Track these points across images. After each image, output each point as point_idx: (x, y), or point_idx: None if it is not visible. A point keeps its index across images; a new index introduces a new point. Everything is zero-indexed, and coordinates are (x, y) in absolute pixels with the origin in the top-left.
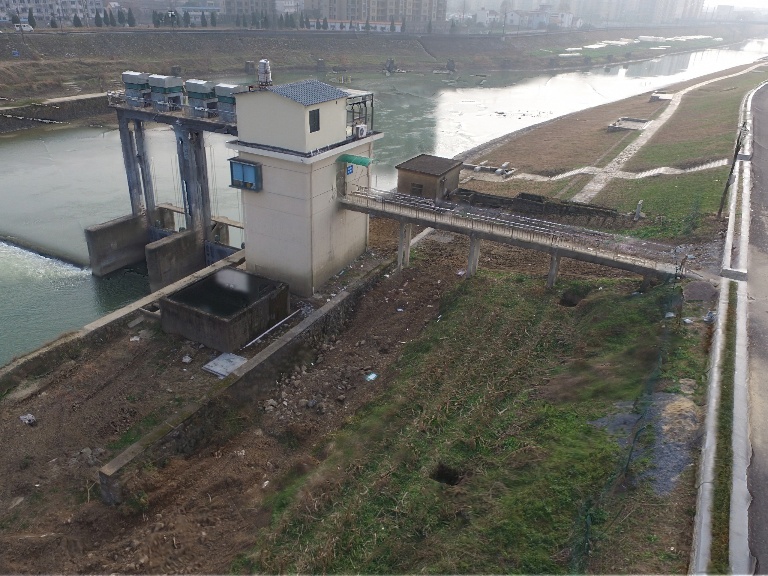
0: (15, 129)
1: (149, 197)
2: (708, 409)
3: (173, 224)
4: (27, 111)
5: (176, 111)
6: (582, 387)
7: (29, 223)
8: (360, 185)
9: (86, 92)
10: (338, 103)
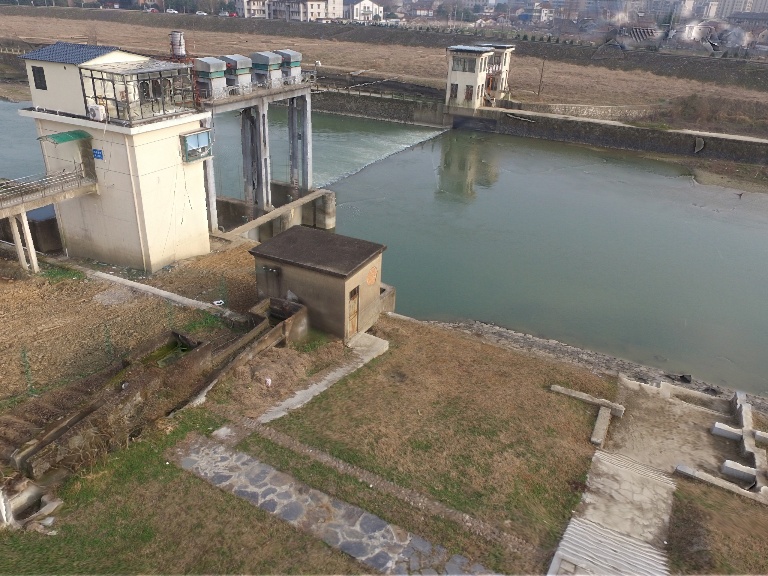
0: (620, 147)
1: (305, 175)
2: None
3: (326, 213)
4: (641, 133)
5: (259, 88)
6: None
7: (369, 186)
8: (121, 182)
9: (742, 133)
10: (68, 69)
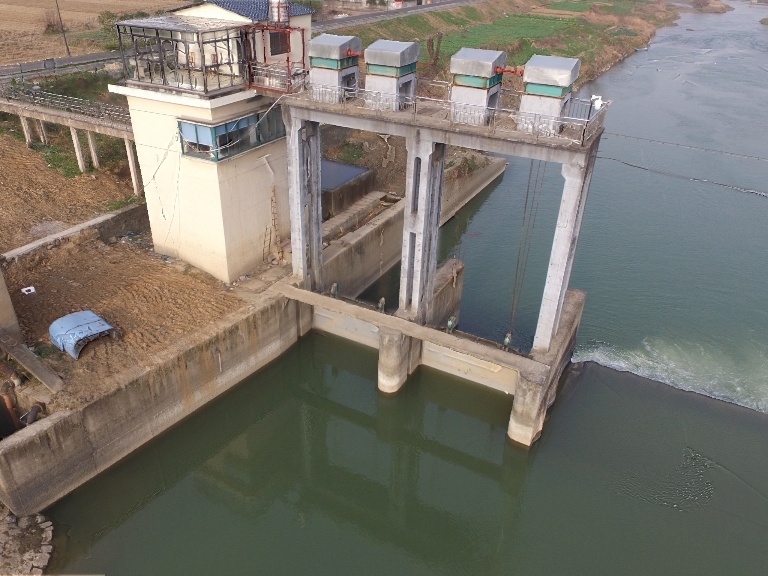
0: None
1: None
2: (107, 63)
3: None
4: None
5: None
6: (124, 99)
7: None
8: None
9: None
10: None
